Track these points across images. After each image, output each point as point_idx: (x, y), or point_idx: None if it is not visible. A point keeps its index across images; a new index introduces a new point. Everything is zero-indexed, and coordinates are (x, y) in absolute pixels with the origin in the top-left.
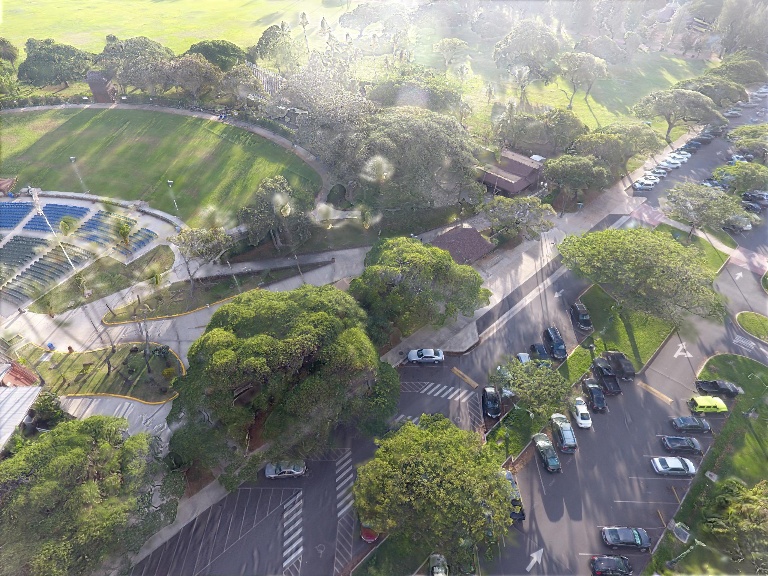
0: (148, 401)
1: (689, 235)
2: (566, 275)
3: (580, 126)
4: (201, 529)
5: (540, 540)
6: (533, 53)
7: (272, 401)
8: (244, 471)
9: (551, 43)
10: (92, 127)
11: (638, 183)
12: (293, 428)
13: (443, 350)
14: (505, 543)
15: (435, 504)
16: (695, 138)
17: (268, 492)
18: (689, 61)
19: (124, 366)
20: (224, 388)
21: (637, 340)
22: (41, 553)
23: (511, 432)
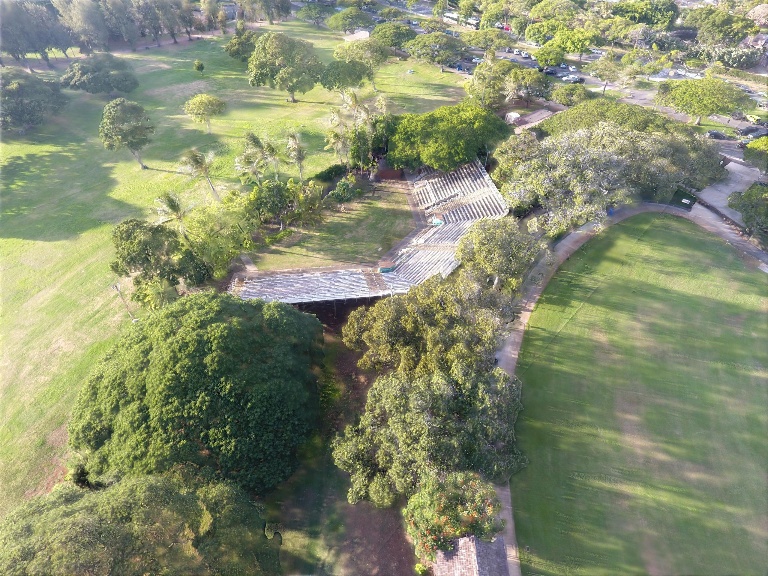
0: None
1: None
2: None
3: None
4: None
5: None
6: None
7: None
8: None
9: (311, 46)
10: (630, 565)
11: None
12: None
13: None
14: None
15: None
16: None
17: None
18: None
19: None
20: None
21: (719, 125)
22: None
23: None
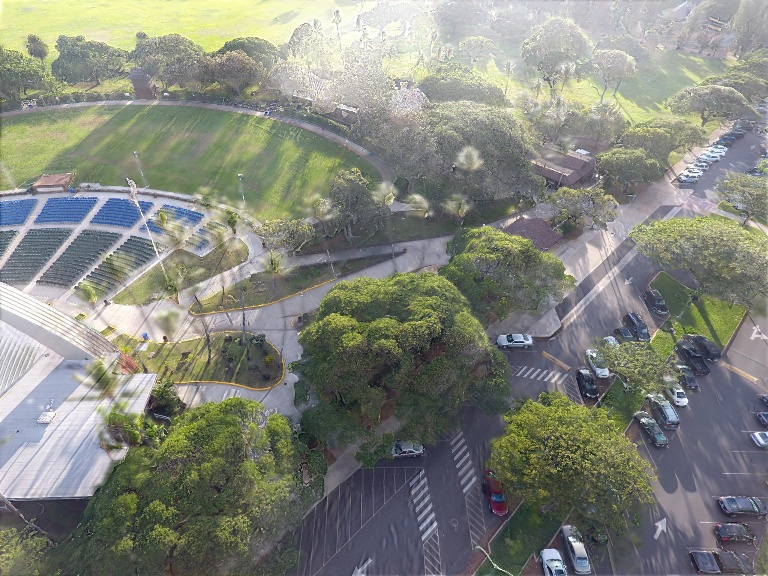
0: (254, 387)
1: (743, 224)
2: (632, 263)
3: (623, 121)
4: (334, 507)
5: (661, 510)
6: (563, 51)
7: (378, 385)
8: (380, 449)
9: (580, 41)
10: (139, 123)
11: (683, 176)
12: (425, 407)
13: (529, 335)
14: (629, 514)
15: (583, 474)
16: (728, 133)
17: (391, 471)
18: (706, 59)
19: (223, 354)
20: (358, 369)
21: (713, 324)
22: (225, 525)
23: (612, 411)
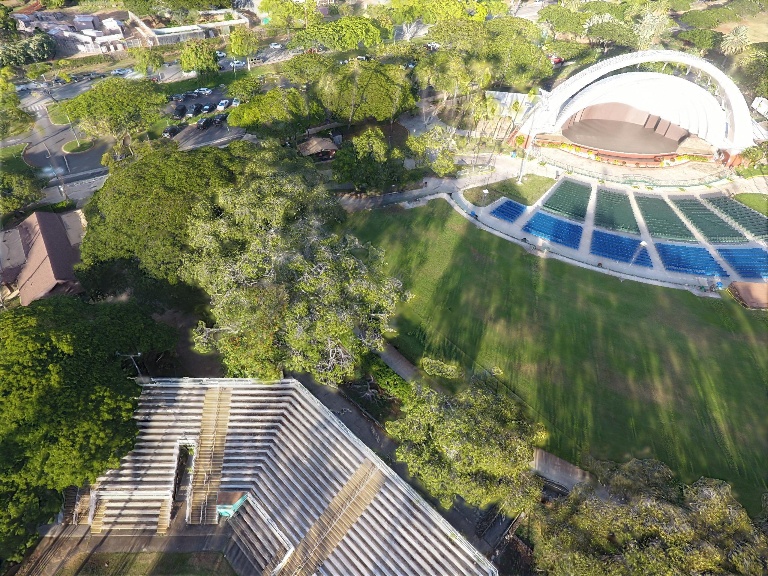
0: None
1: None
2: None
3: None
4: None
5: None
6: None
7: (374, 118)
8: None
9: None
10: None
11: None
12: None
13: None
14: None
15: None
16: None
17: None
18: None
19: None
20: None
21: None
22: None
23: None
